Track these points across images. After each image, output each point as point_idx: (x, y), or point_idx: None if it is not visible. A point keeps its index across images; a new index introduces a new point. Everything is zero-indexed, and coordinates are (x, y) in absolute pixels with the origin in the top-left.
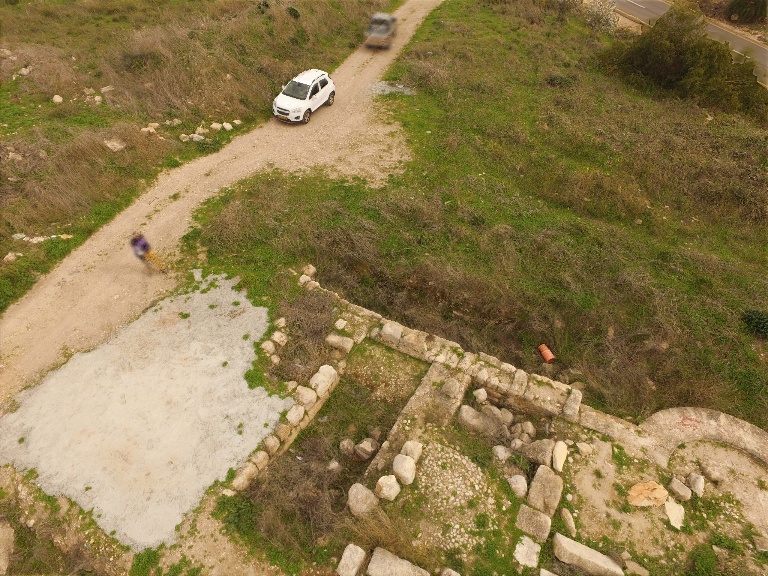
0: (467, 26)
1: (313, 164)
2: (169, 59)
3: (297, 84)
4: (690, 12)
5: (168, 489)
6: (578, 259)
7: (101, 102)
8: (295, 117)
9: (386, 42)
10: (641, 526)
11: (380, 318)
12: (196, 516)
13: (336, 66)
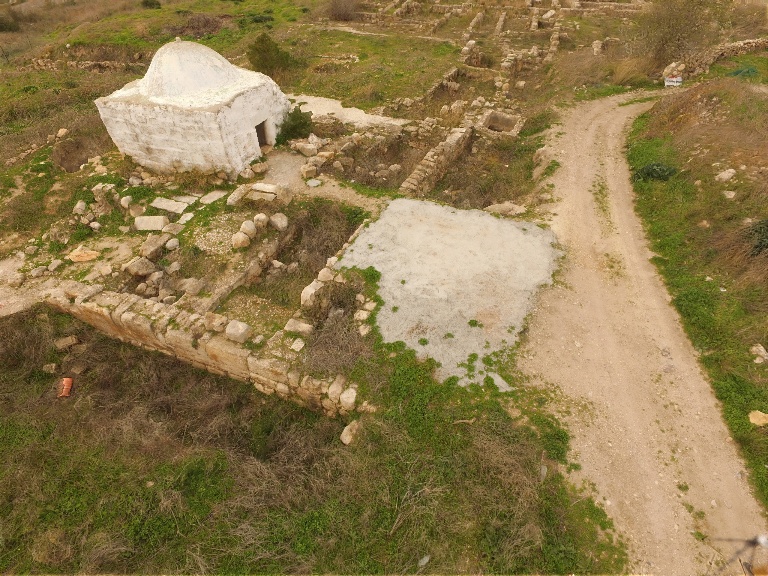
0: None
1: None
2: None
3: None
4: None
5: (403, 216)
6: None
7: None
8: None
9: None
10: (104, 243)
11: (250, 354)
12: (380, 210)
13: None
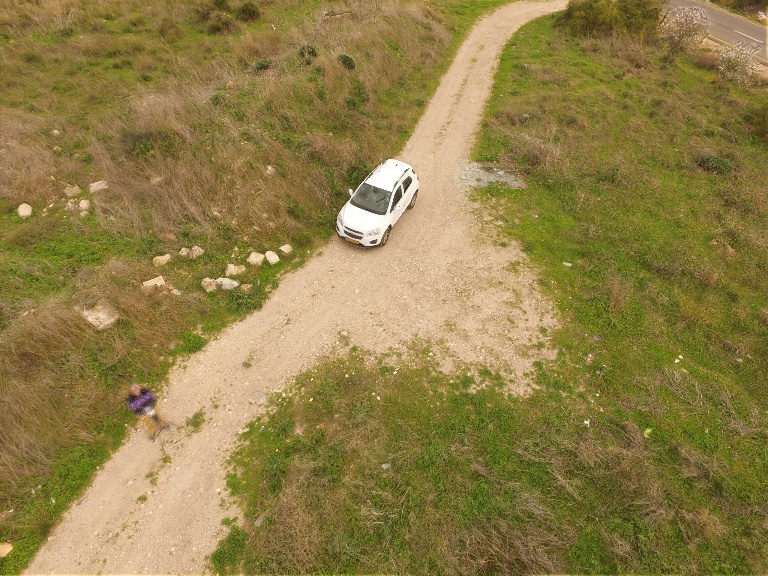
0: (559, 72)
1: (409, 337)
2: (186, 139)
3: (372, 189)
4: None
5: None
6: None
7: (88, 211)
8: (370, 241)
9: (461, 95)
10: None
11: None
12: None
13: (407, 137)
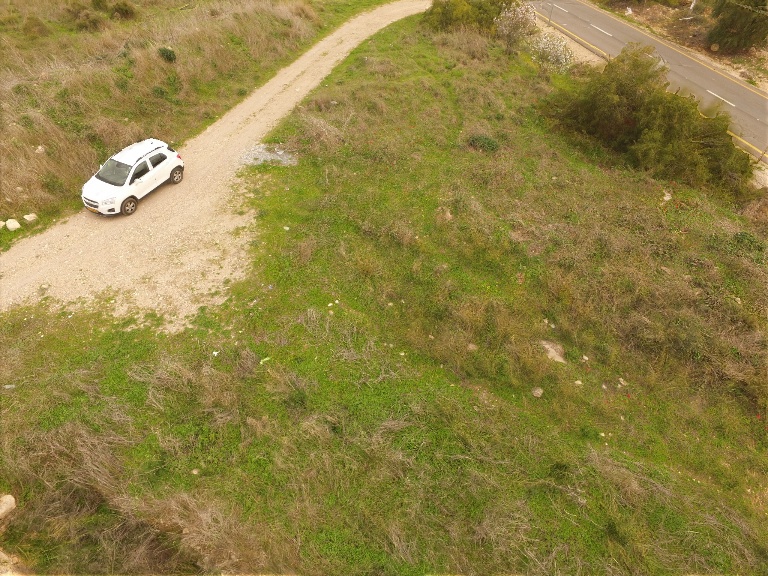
0: (393, 63)
1: (103, 288)
2: None
3: (116, 164)
4: (645, 57)
5: None
6: (426, 479)
7: None
8: (108, 209)
9: (290, 86)
10: None
11: None
12: None
13: (210, 122)
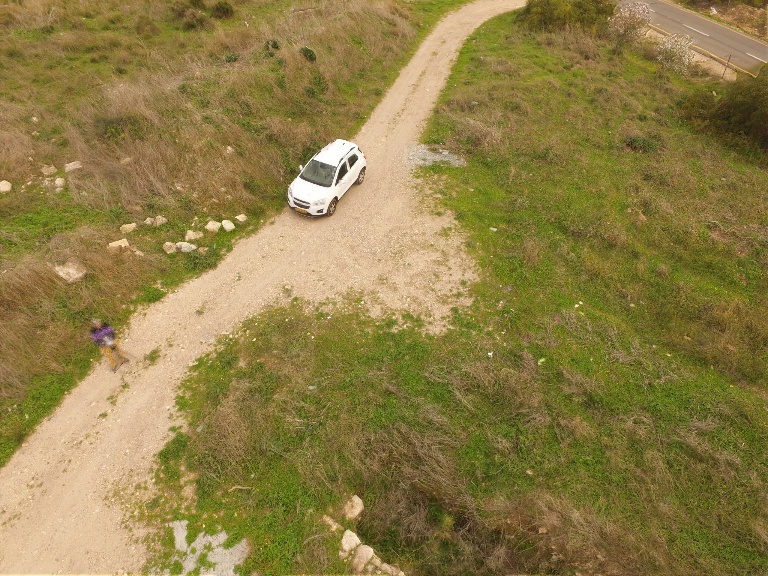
0: (512, 63)
1: (345, 289)
2: (154, 123)
3: (319, 165)
4: None
5: None
6: (759, 479)
7: (63, 187)
8: (317, 210)
9: (418, 85)
10: None
11: None
12: None
13: (362, 123)
